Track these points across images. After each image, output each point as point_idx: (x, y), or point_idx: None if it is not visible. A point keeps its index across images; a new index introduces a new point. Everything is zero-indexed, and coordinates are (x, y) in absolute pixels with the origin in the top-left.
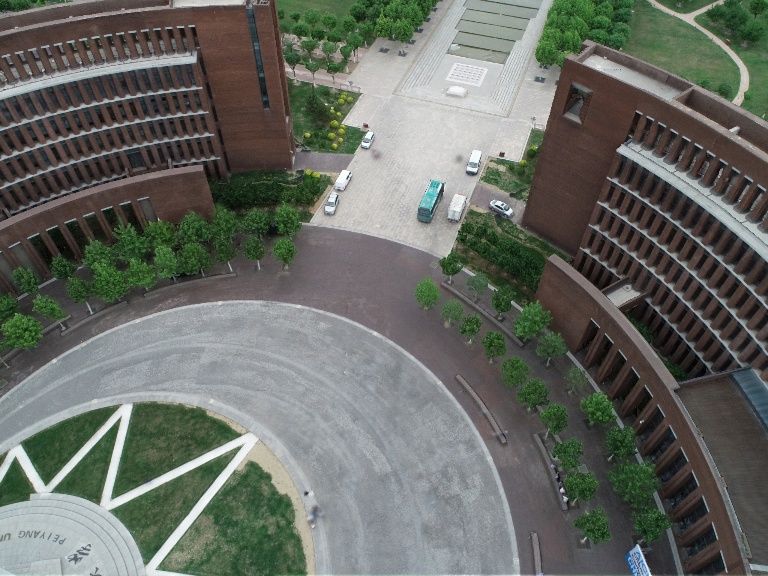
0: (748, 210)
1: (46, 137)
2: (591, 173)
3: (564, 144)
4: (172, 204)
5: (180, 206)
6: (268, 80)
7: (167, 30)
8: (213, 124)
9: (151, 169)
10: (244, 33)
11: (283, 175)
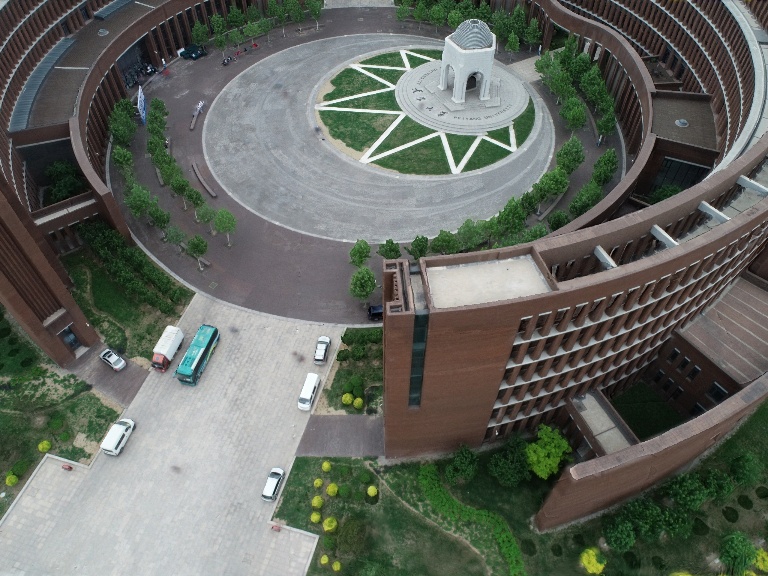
0: None
1: None
2: None
3: None
4: None
5: None
6: None
7: None
8: None
9: None
10: None
11: None
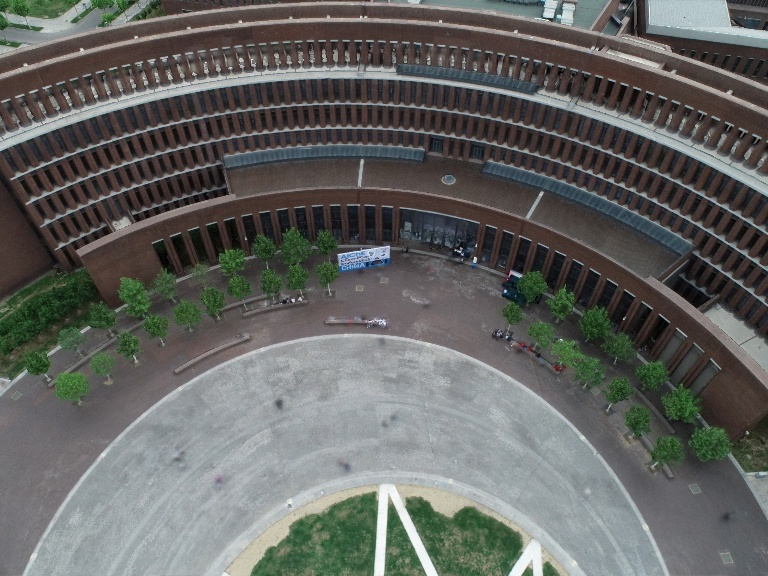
0: (107, 95)
1: None
2: None
3: None
4: None
5: None
6: None
7: None
8: None
9: None
10: None
11: None
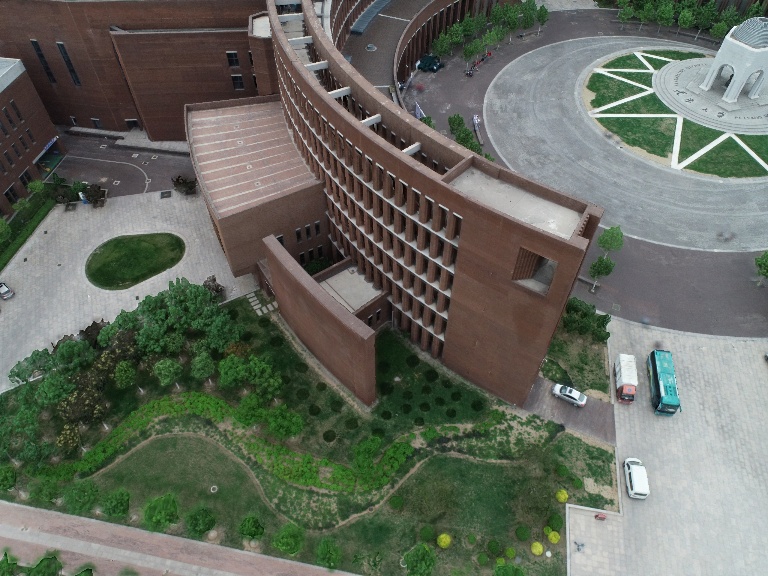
0: None
1: None
2: None
3: None
4: None
5: None
6: None
7: None
8: None
9: None
10: None
11: None
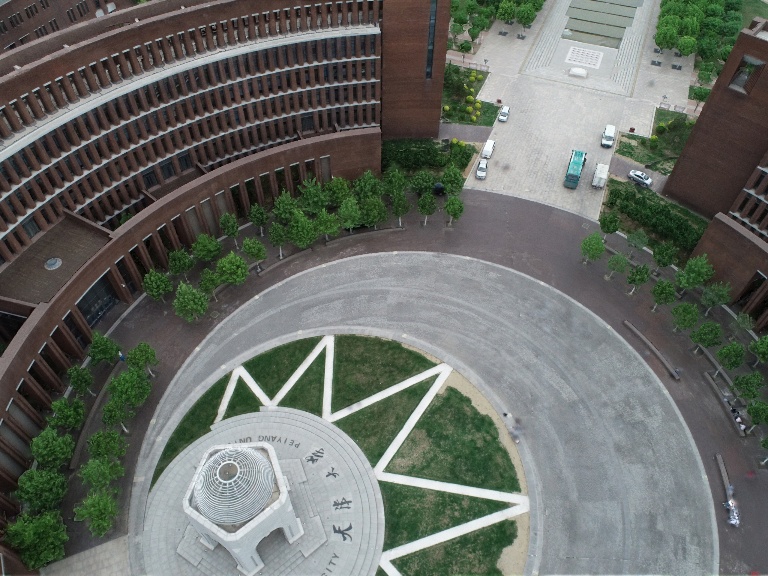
0: None
1: (241, 98)
2: (750, 141)
3: (725, 114)
4: (347, 163)
5: (353, 165)
6: (436, 52)
7: (358, 3)
8: (380, 92)
9: (319, 133)
10: (425, 7)
11: (430, 143)
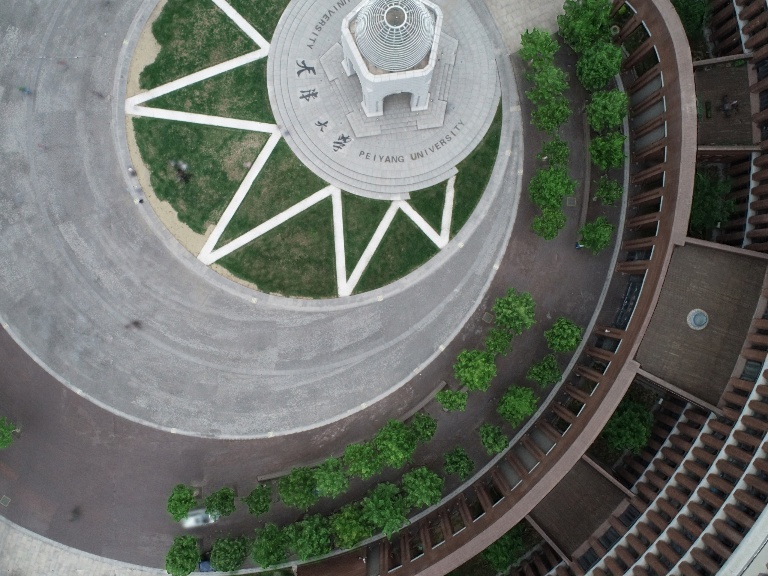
0: None
1: None
2: None
3: None
4: None
5: None
6: None
7: None
8: None
9: None
10: None
11: None
